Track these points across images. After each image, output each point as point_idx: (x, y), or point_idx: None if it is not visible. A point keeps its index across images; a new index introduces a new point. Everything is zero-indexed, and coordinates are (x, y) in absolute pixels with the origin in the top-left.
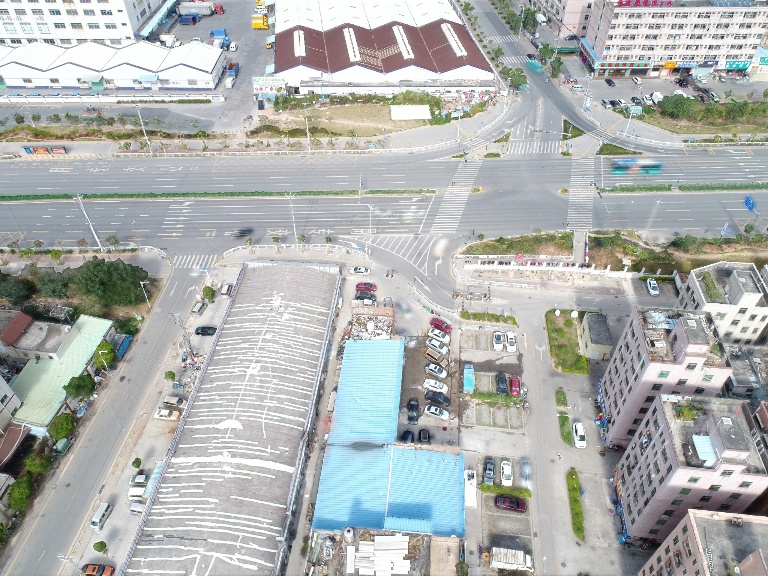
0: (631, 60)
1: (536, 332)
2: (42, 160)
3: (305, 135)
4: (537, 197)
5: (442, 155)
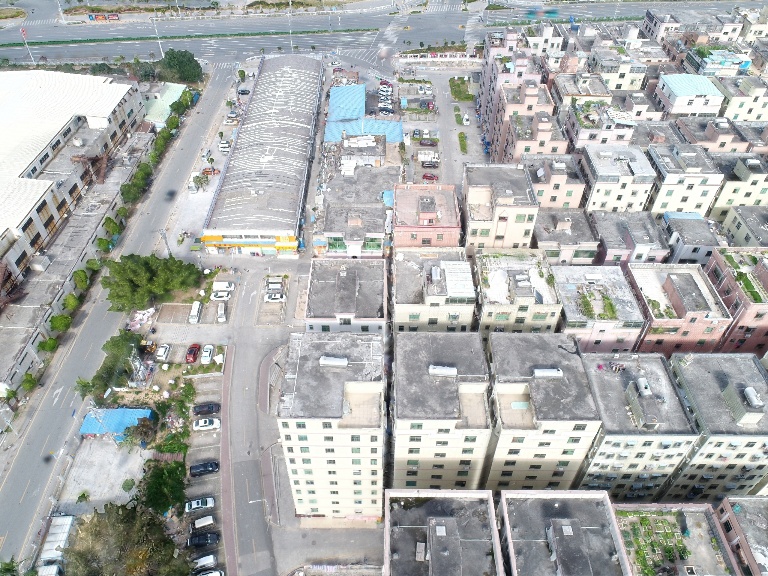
0: None
1: (443, 87)
2: (102, 24)
3: (286, 6)
4: (445, 30)
5: (382, 13)
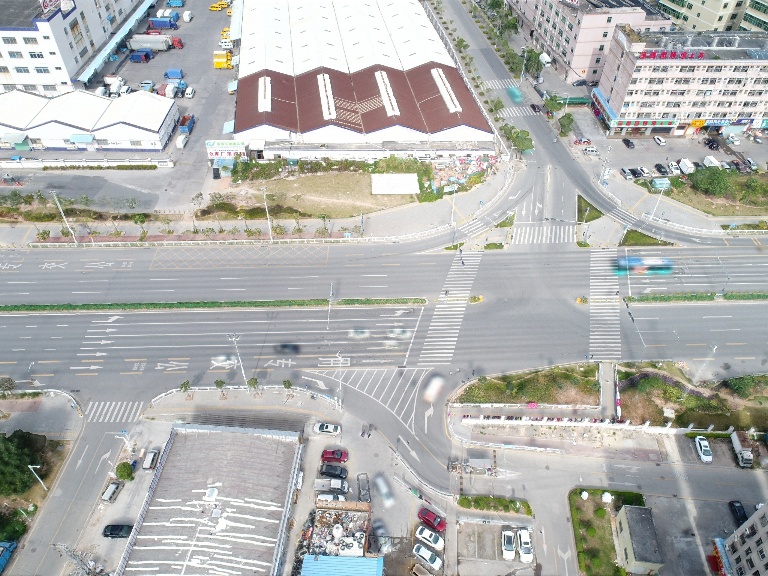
0: (653, 118)
1: (558, 526)
2: None
3: None
4: (550, 309)
5: (433, 245)
